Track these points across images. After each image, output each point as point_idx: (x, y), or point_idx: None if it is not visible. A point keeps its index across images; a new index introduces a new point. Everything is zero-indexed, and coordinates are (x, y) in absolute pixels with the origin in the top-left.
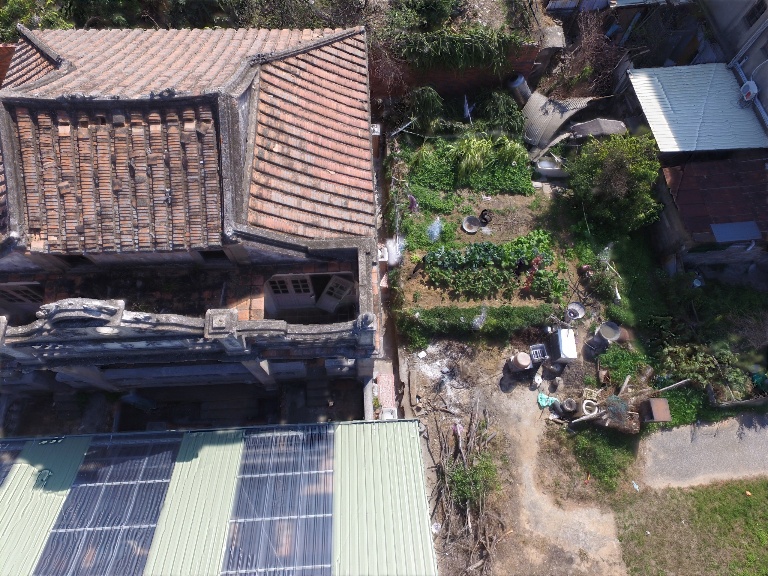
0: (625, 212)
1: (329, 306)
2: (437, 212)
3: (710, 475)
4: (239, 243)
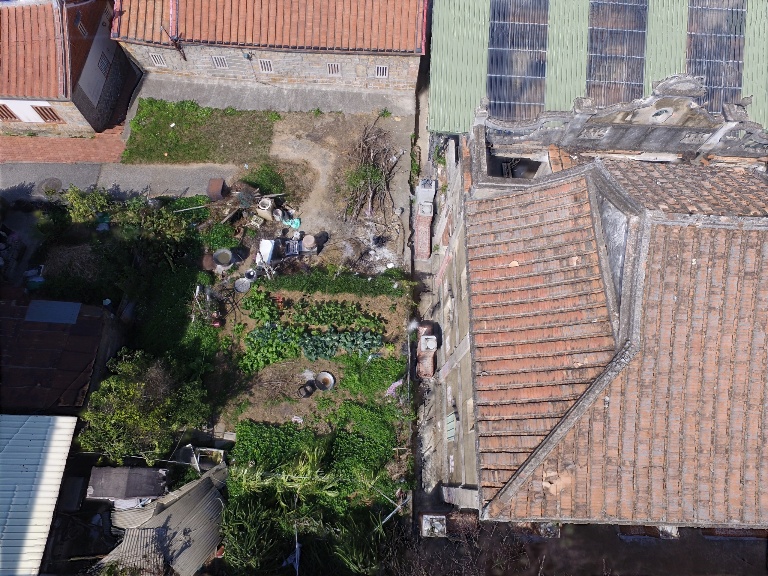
0: (153, 364)
1: None
2: (359, 404)
3: (187, 168)
4: None
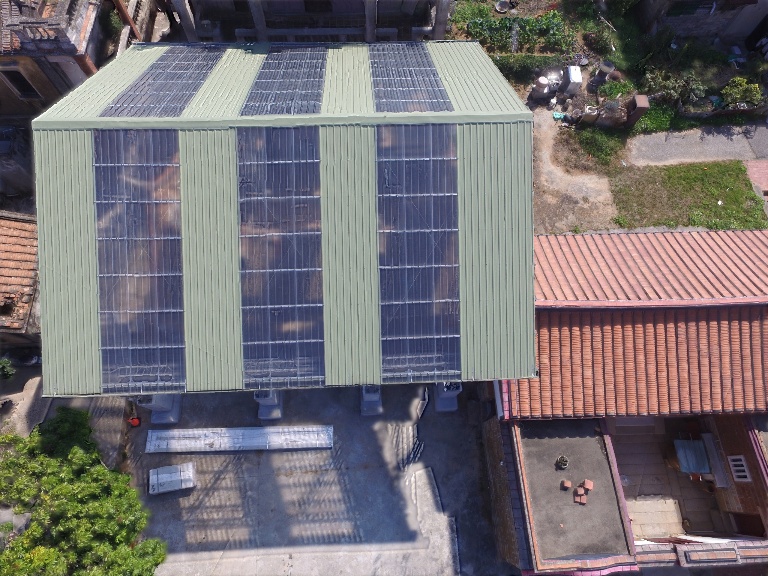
0: None
1: (411, 6)
2: (476, 0)
3: (678, 160)
4: None
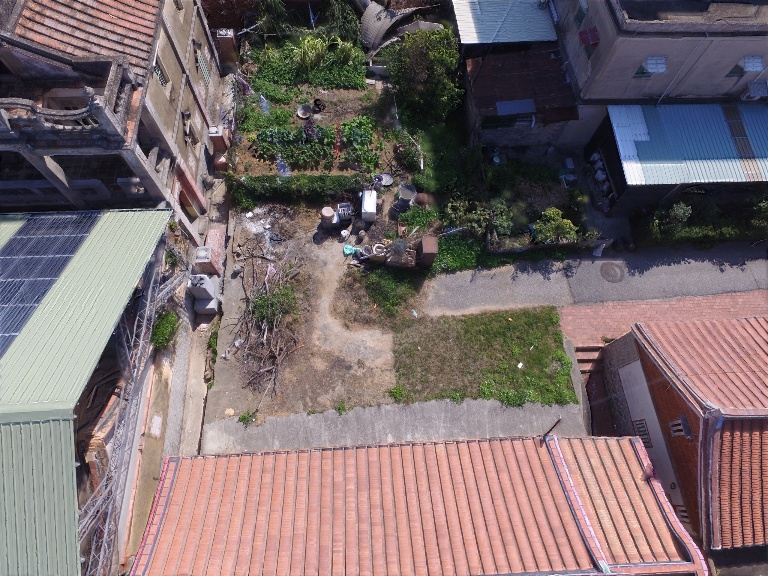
0: (433, 97)
1: None
2: (277, 102)
3: (481, 307)
4: (4, 46)
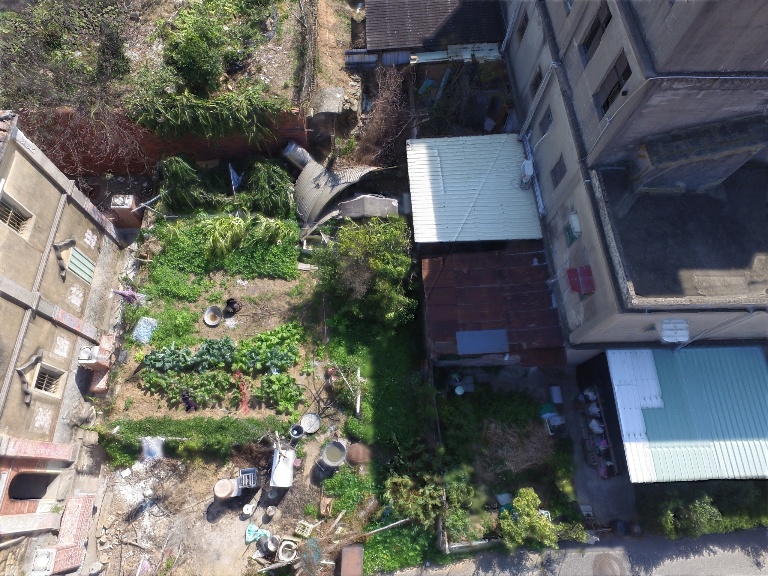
0: (376, 309)
1: None
2: (181, 299)
3: None
4: None
